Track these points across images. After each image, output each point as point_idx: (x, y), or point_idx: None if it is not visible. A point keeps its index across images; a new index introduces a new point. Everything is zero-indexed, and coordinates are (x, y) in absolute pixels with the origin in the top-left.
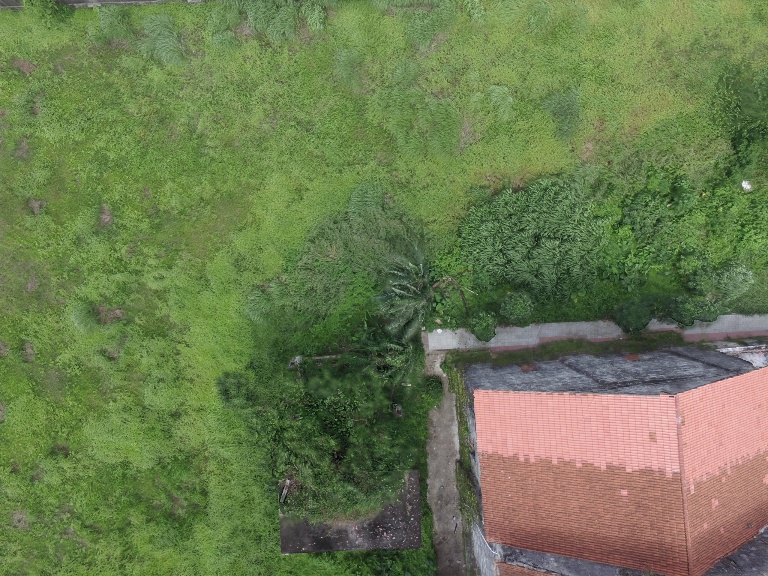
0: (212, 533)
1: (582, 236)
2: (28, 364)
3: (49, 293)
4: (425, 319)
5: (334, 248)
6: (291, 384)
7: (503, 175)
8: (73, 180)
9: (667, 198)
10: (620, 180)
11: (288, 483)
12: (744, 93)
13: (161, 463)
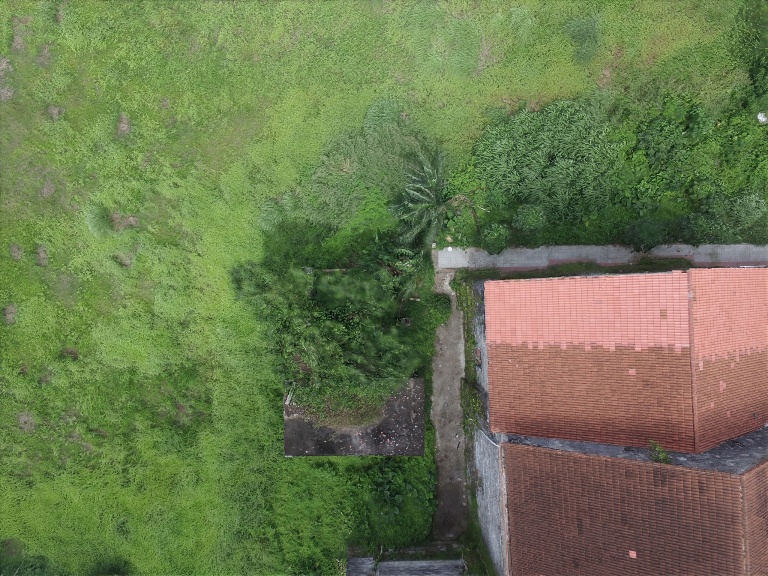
0: (216, 440)
1: (596, 157)
2: (41, 267)
3: (64, 199)
4: (436, 232)
5: (348, 162)
6: (300, 296)
7: (519, 98)
8: (93, 88)
9: (682, 125)
10: (636, 105)
11: (294, 385)
12: (763, 26)
13: (168, 370)
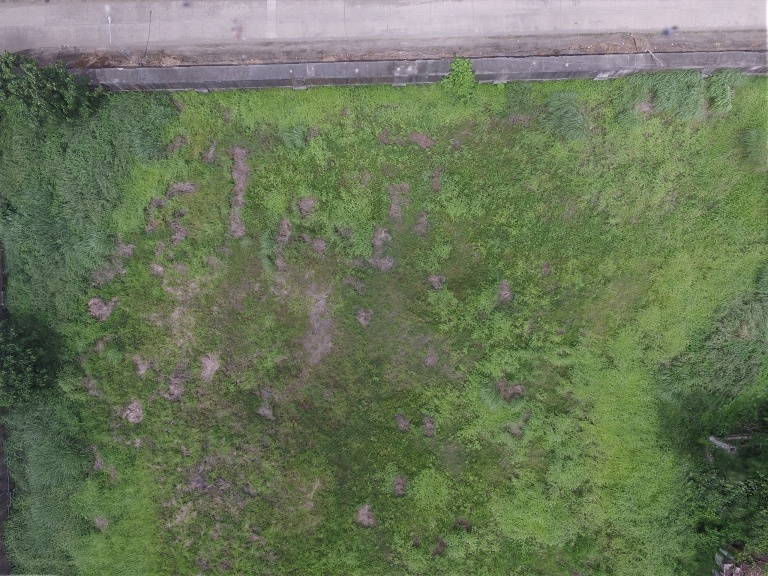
0: None
1: None
2: (429, 438)
3: (448, 367)
4: None
5: (746, 329)
6: (697, 463)
7: None
8: (472, 255)
9: None
10: None
11: (738, 571)
12: None
13: (565, 540)
